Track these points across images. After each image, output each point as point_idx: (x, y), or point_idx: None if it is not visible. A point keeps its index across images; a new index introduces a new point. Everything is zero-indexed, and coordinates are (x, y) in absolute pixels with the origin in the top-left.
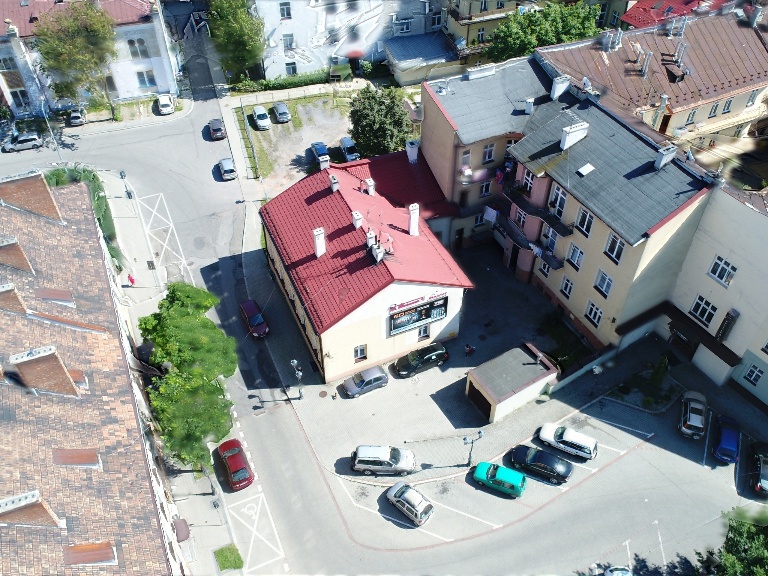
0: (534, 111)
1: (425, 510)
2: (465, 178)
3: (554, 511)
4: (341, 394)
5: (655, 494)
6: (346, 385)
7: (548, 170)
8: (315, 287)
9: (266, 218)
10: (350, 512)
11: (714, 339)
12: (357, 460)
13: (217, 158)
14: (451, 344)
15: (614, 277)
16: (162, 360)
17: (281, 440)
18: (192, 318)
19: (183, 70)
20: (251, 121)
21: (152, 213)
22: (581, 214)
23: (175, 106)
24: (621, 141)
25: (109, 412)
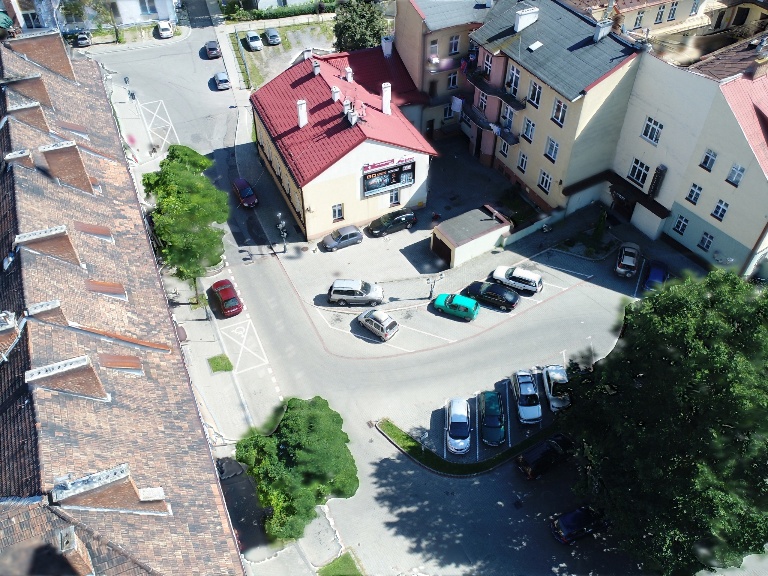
0: (494, 5)
1: (390, 326)
2: (433, 66)
3: (502, 330)
4: (321, 248)
5: (590, 318)
6: (325, 240)
7: (503, 49)
8: (298, 151)
9: (256, 103)
10: (326, 332)
11: (647, 196)
12: (333, 290)
13: (213, 73)
14: (420, 213)
15: (560, 140)
16: (163, 200)
17: (267, 282)
18: (189, 172)
19: (182, 3)
20: (244, 43)
21: (153, 115)
22: (532, 88)
23: (174, 31)
24: (567, 22)
25: (119, 211)
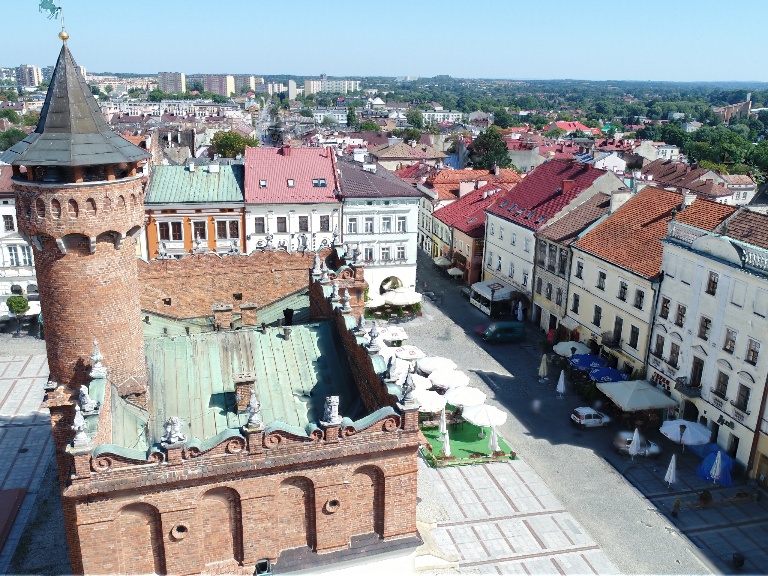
0: None
1: None
2: None
3: None
4: None
5: None
6: None
7: None
8: None
9: None
10: None
11: None
12: None
13: None
14: None
15: None
16: None
17: None
18: None
19: None
20: None
21: None
22: None
23: None
24: None
25: None
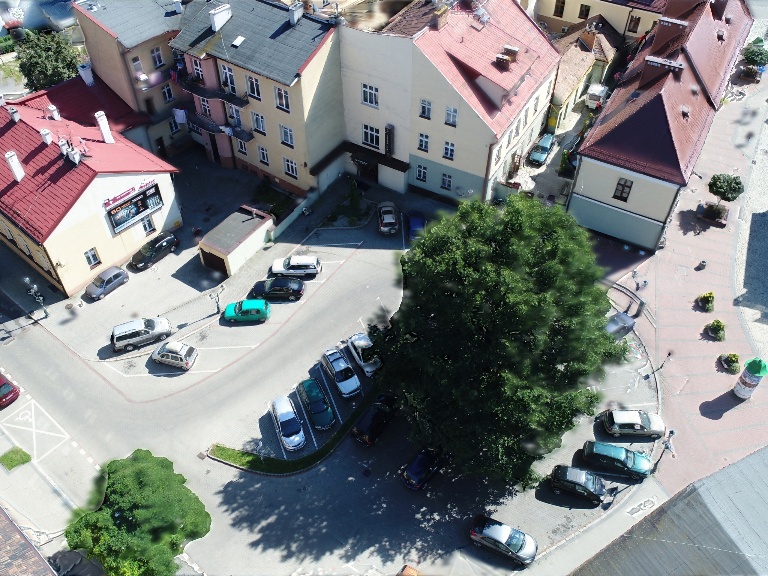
0: (184, 10)
1: (188, 354)
2: (143, 84)
3: (299, 319)
4: (86, 300)
5: (373, 281)
6: (88, 291)
7: (208, 51)
8: (24, 207)
9: None
10: (123, 383)
11: (385, 156)
12: (115, 339)
13: None
14: (179, 233)
15: (291, 126)
16: None
17: (38, 354)
18: None
19: None
20: None
21: None
22: (249, 82)
23: None
24: (260, 12)
25: None
